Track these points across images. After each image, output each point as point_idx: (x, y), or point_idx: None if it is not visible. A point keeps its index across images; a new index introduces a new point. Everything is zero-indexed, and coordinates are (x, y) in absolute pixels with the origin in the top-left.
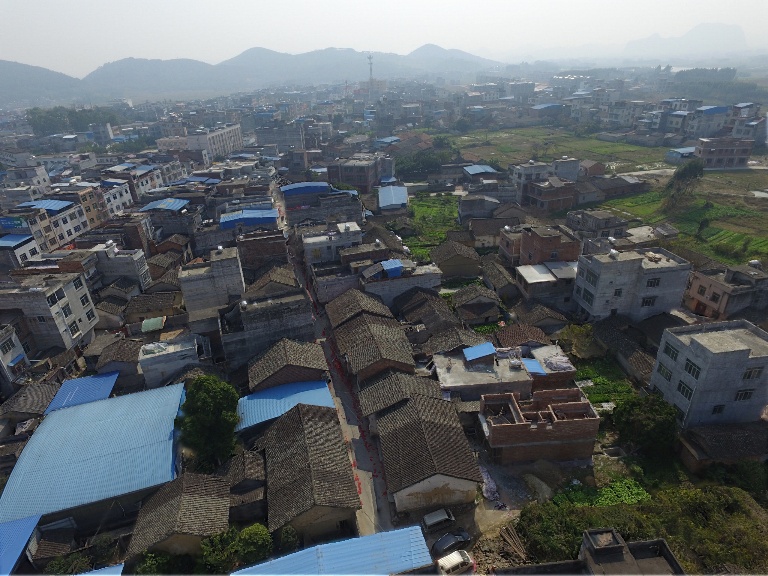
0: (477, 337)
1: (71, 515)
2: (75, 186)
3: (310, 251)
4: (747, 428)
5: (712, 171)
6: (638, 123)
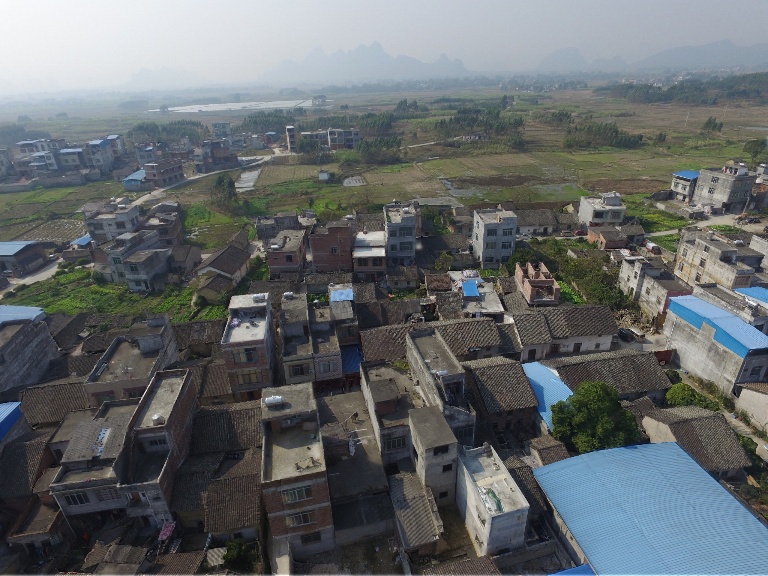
0: None
1: None
2: None
3: (265, 347)
4: (521, 246)
5: (176, 187)
6: (29, 168)
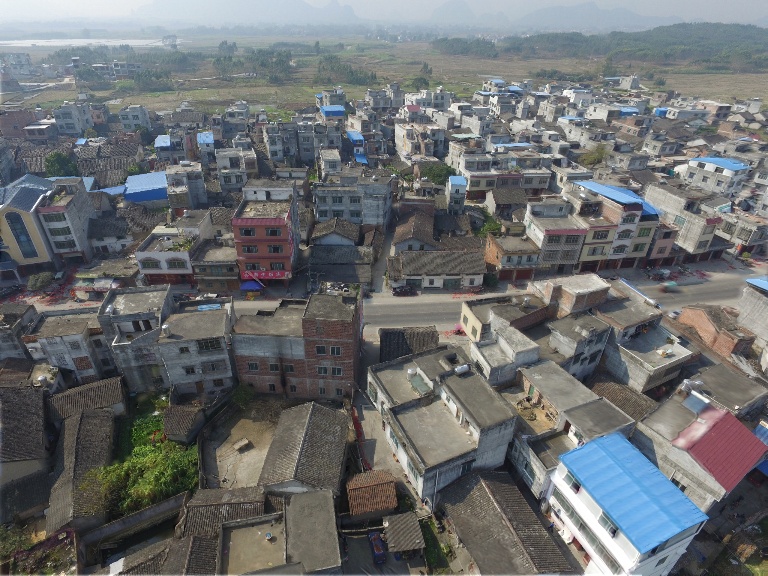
0: None
1: None
2: None
3: None
4: None
5: None
6: None
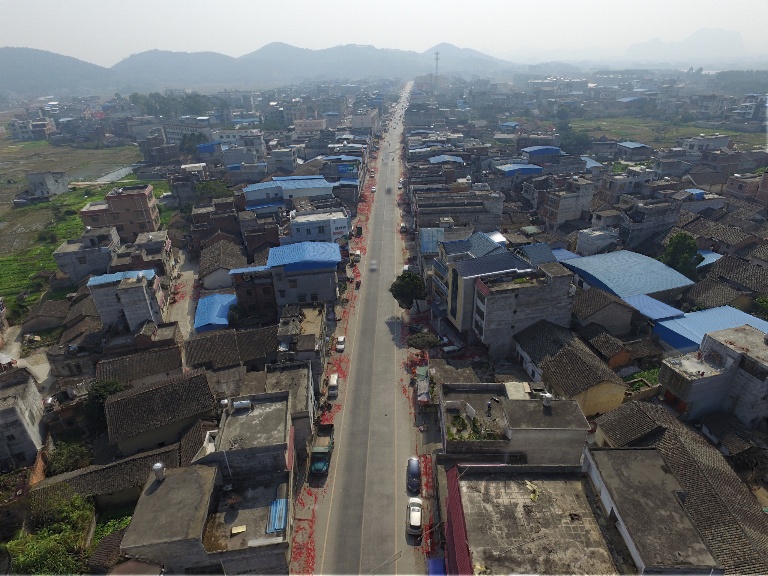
0: None
1: (653, 297)
2: (349, 147)
3: (619, 185)
4: None
5: None
6: (732, 113)
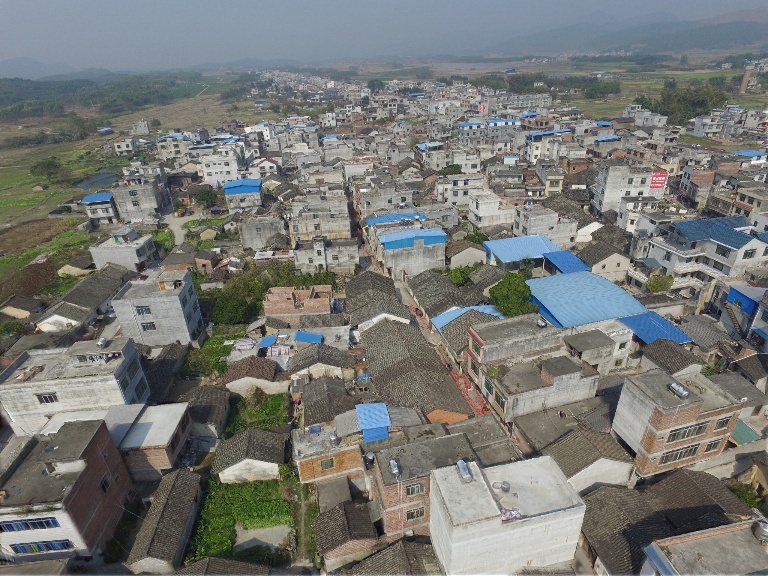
0: (298, 363)
1: None
2: None
3: None
4: None
5: None
6: None
